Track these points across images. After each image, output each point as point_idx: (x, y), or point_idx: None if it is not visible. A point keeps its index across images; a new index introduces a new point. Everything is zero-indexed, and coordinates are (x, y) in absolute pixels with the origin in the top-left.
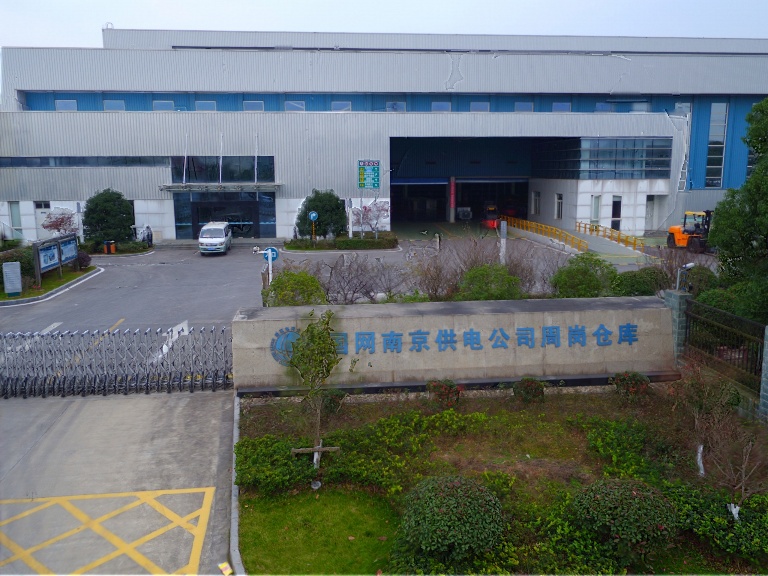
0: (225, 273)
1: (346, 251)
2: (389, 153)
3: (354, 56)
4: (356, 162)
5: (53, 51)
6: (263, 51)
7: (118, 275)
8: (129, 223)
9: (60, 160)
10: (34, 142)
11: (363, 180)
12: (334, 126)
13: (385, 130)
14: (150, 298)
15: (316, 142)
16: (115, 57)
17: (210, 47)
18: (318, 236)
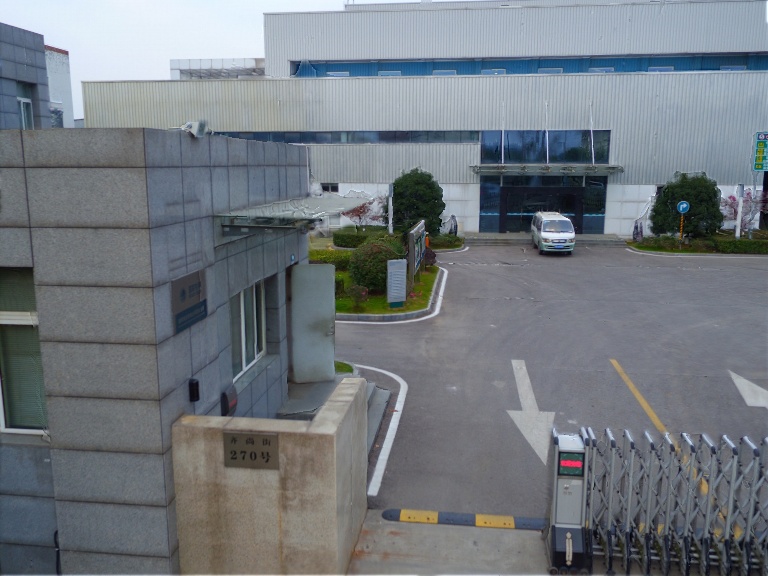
0: (624, 282)
1: (734, 255)
2: (767, 126)
3: (687, 7)
4: (720, 138)
5: (331, 15)
6: (571, 6)
7: (477, 278)
8: (441, 211)
9: (352, 135)
10: (326, 114)
11: (761, 159)
12: (695, 90)
13: (765, 95)
14: (588, 320)
15: (668, 112)
16: (398, 20)
17: (508, 3)
18: (686, 234)
